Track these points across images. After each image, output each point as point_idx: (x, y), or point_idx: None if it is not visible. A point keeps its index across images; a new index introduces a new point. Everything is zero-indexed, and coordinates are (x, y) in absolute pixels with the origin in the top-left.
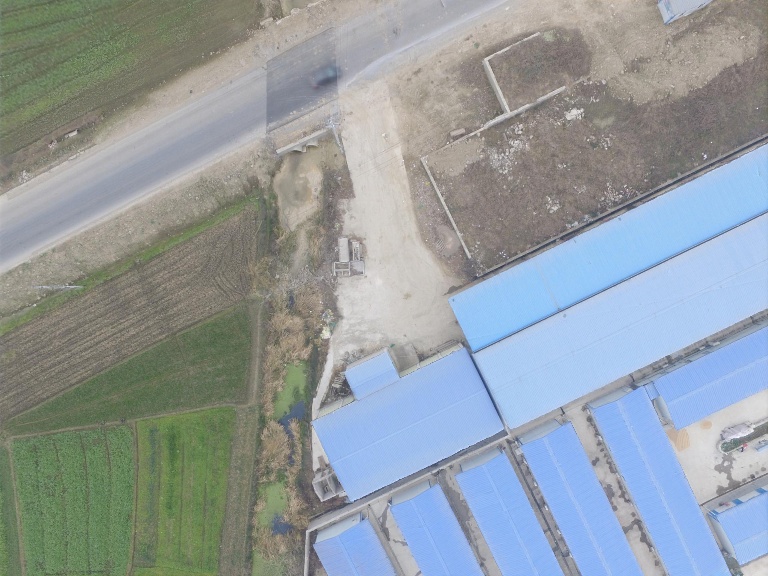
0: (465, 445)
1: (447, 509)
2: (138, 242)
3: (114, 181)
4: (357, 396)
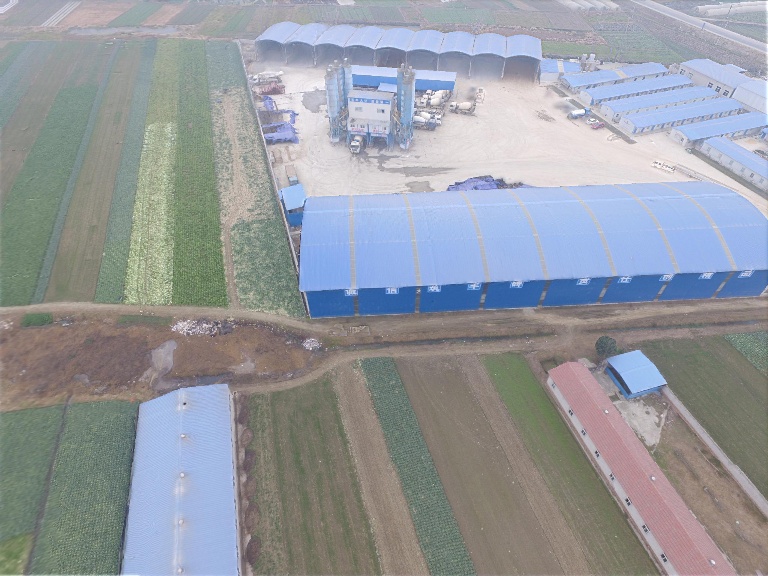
0: (721, 81)
1: (684, 83)
2: (741, 52)
3: (763, 47)
4: (725, 65)
